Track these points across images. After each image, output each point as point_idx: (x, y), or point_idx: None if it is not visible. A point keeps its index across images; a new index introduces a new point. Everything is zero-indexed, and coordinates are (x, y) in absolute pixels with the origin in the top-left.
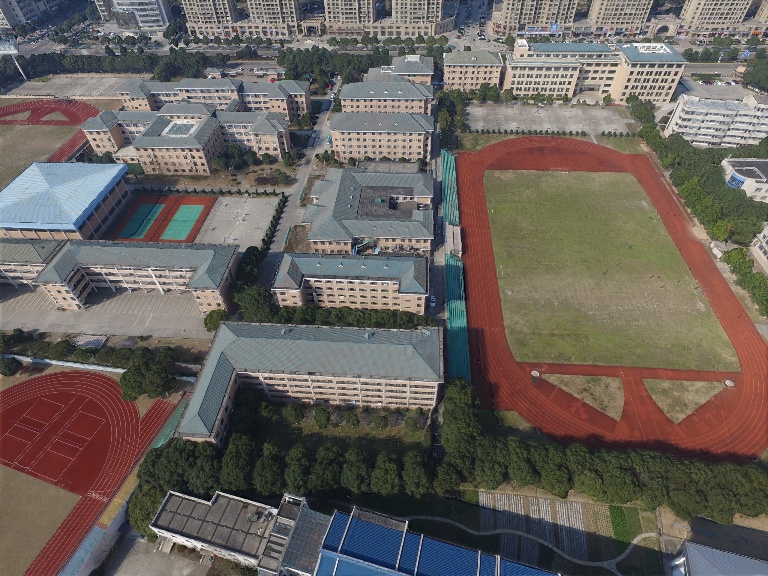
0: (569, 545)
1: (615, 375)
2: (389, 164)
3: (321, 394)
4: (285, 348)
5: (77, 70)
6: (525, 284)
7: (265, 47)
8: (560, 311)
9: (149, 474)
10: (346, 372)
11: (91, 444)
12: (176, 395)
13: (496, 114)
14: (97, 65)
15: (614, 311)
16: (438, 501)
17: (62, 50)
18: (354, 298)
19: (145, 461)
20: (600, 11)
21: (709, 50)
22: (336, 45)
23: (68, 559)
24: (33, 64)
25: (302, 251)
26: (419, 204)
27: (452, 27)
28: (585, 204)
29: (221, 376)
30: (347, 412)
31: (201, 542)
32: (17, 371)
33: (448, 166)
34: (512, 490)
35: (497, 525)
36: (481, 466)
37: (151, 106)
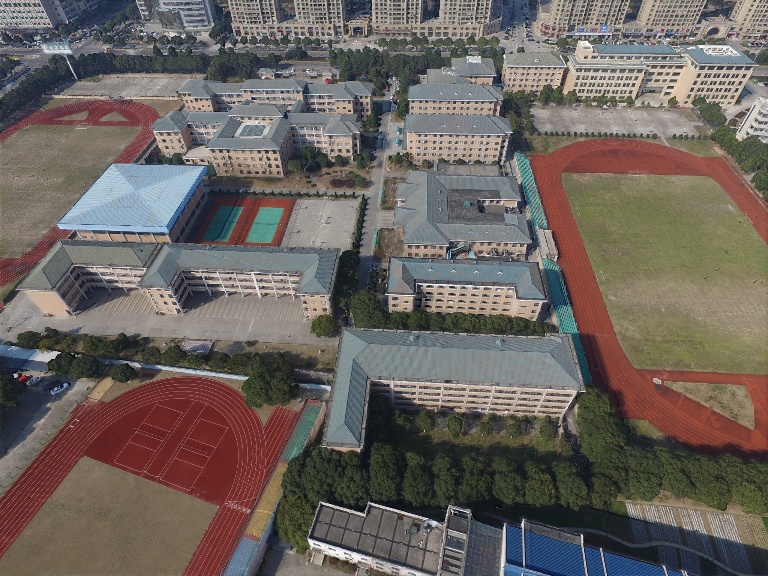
0: (730, 558)
1: (739, 383)
2: (469, 167)
3: (448, 402)
4: (418, 355)
5: (127, 70)
6: (627, 289)
7: (312, 47)
8: (669, 317)
9: (295, 484)
10: (484, 380)
11: (218, 452)
12: (295, 402)
13: (561, 116)
14: (149, 65)
15: (724, 317)
16: (586, 512)
17: None
18: (463, 303)
19: (289, 471)
20: (651, 13)
21: (766, 52)
22: (385, 46)
23: (222, 572)
24: (84, 64)
25: (393, 255)
26: (506, 207)
27: (499, 28)
28: (671, 208)
29: (357, 384)
30: (474, 420)
31: (365, 555)
32: (131, 377)
33: (525, 169)
34: (659, 501)
35: (652, 537)
36: (635, 477)
37: (214, 107)
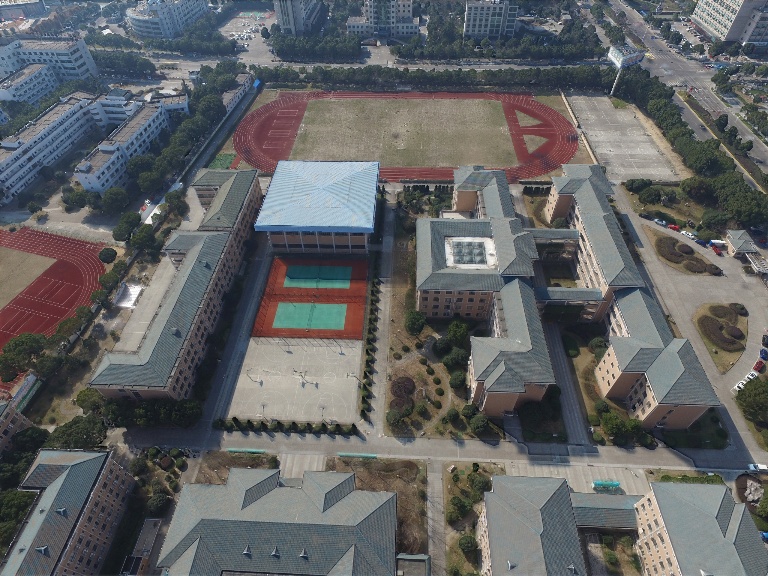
0: None
1: None
2: None
3: None
4: None
5: None
6: None
7: None
8: None
9: None
10: None
11: (7, 336)
12: None
13: None
14: (666, 127)
15: None
16: None
17: (707, 89)
18: None
19: None
20: None
21: None
22: None
23: None
24: (631, 86)
25: (213, 480)
26: None
27: None
28: None
29: None
30: None
31: None
32: None
33: None
34: None
35: None
36: None
37: (560, 206)
